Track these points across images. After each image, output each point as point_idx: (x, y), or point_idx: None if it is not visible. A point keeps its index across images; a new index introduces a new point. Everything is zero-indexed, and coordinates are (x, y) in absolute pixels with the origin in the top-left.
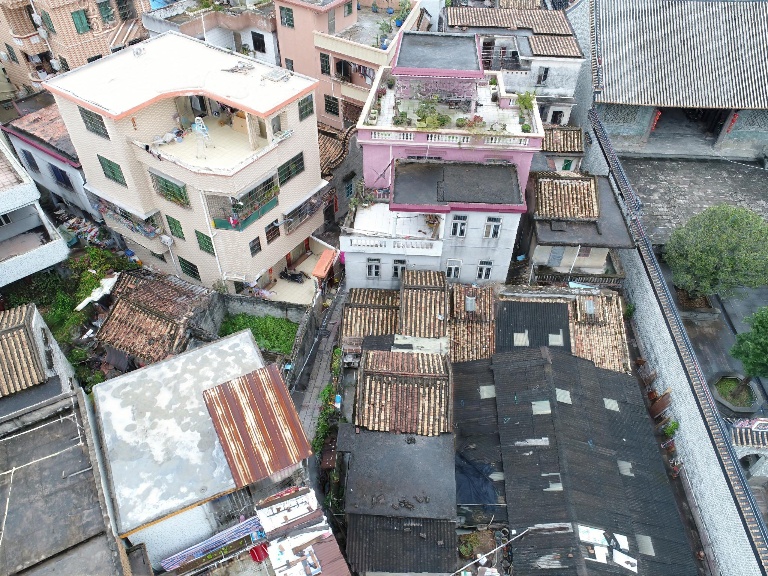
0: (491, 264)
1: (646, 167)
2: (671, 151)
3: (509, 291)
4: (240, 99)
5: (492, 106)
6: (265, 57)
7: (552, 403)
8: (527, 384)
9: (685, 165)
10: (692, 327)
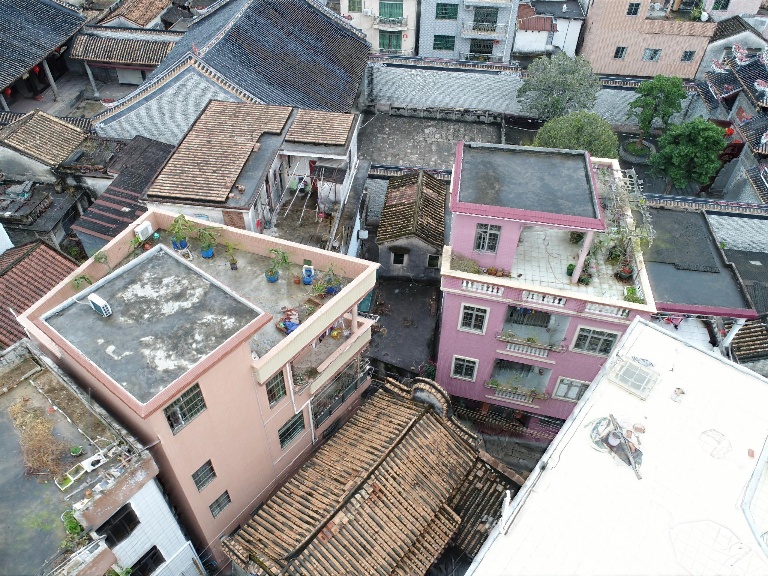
0: None
1: None
2: None
3: None
4: (736, 437)
5: None
6: (140, 532)
7: None
8: None
9: (365, 152)
10: None
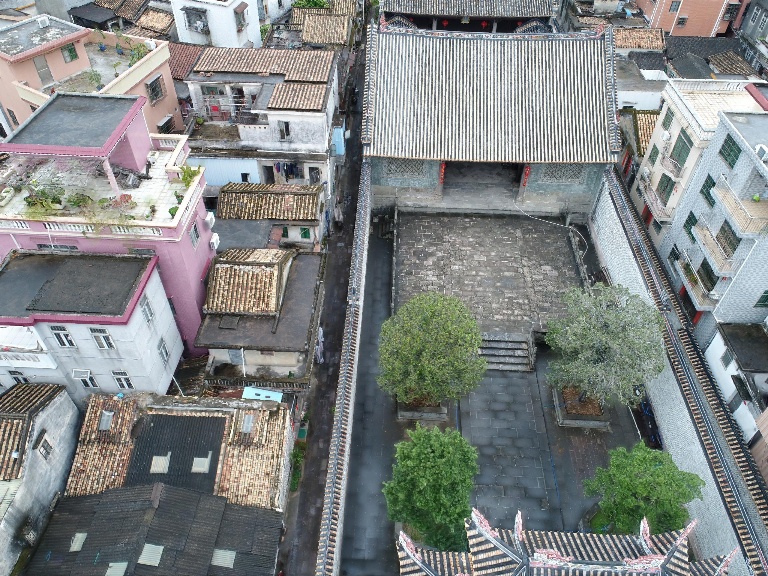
0: (126, 374)
1: (434, 224)
2: (468, 205)
3: (156, 404)
4: None
5: (162, 179)
6: None
7: (128, 567)
8: (118, 536)
9: (478, 222)
10: (414, 429)
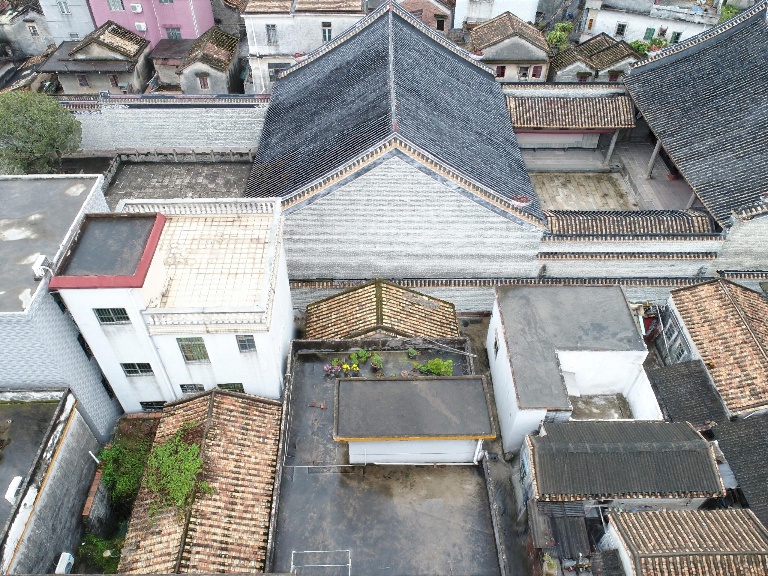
0: None
1: None
2: None
3: None
4: None
5: None
6: None
7: None
8: None
9: None
10: None
